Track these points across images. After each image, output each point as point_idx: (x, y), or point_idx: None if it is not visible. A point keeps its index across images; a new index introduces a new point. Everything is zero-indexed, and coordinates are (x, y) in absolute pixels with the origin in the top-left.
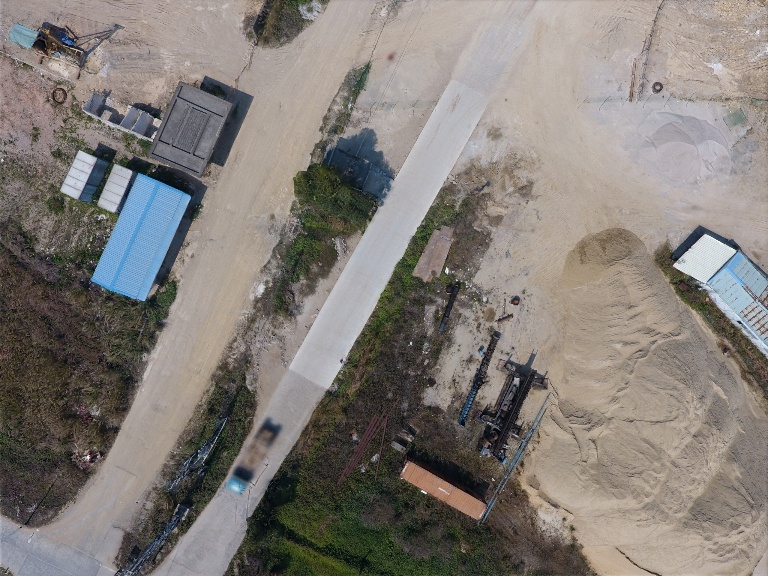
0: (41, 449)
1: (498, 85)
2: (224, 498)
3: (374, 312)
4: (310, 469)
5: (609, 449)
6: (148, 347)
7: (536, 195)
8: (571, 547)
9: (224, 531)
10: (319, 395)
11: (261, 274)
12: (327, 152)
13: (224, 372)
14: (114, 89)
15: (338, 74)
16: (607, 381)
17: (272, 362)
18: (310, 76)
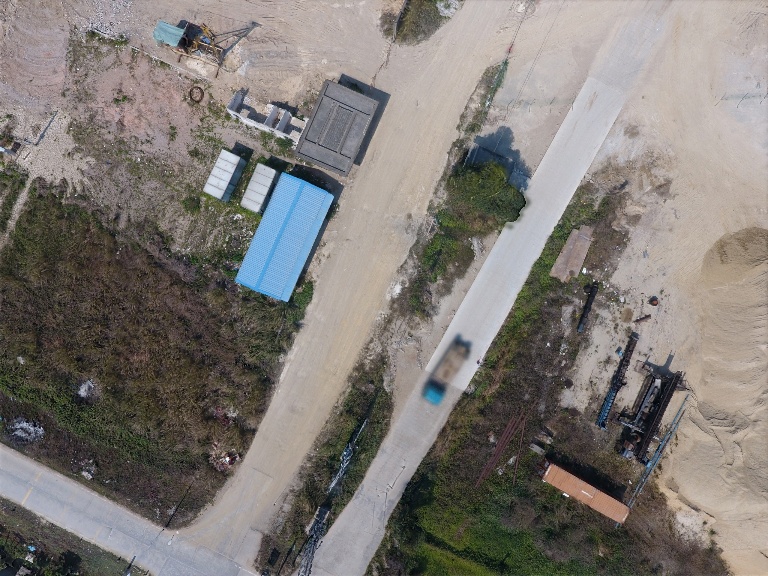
0: (178, 451)
1: (635, 82)
2: (361, 501)
3: (510, 313)
4: (447, 471)
5: (756, 452)
6: (285, 348)
7: (674, 194)
8: (710, 551)
9: (362, 534)
10: (455, 397)
11: (397, 274)
12: (471, 151)
13: (361, 373)
14: (252, 87)
15: (475, 72)
16: (753, 383)
17: (408, 363)
18: (447, 74)
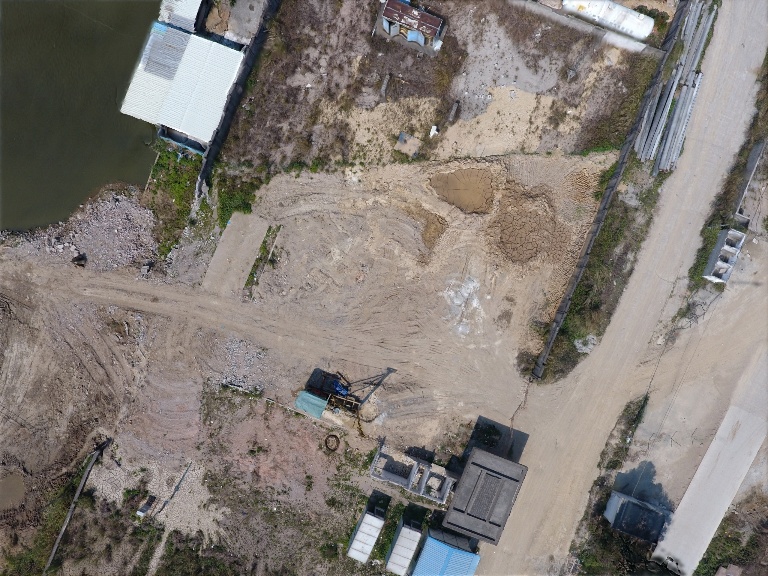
0: None
1: None
2: None
3: None
4: None
5: None
6: None
7: None
8: None
9: None
10: None
11: None
12: (620, 506)
13: None
14: (389, 435)
15: (615, 407)
16: None
17: None
18: (587, 411)
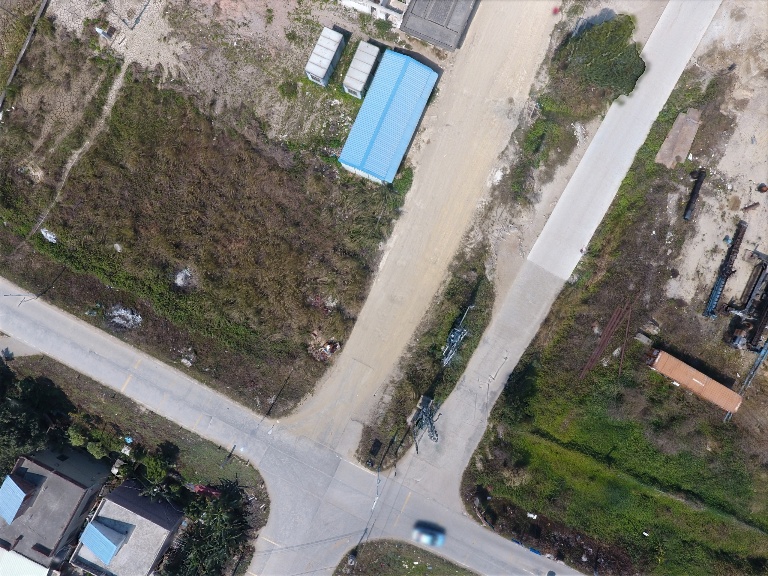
0: (276, 341)
1: None
2: (463, 392)
3: (614, 200)
4: (550, 363)
5: None
6: (384, 236)
7: None
8: None
9: (464, 426)
10: (558, 287)
11: (499, 161)
12: (579, 27)
13: (461, 262)
14: None
15: None
16: None
17: (510, 252)
18: None
